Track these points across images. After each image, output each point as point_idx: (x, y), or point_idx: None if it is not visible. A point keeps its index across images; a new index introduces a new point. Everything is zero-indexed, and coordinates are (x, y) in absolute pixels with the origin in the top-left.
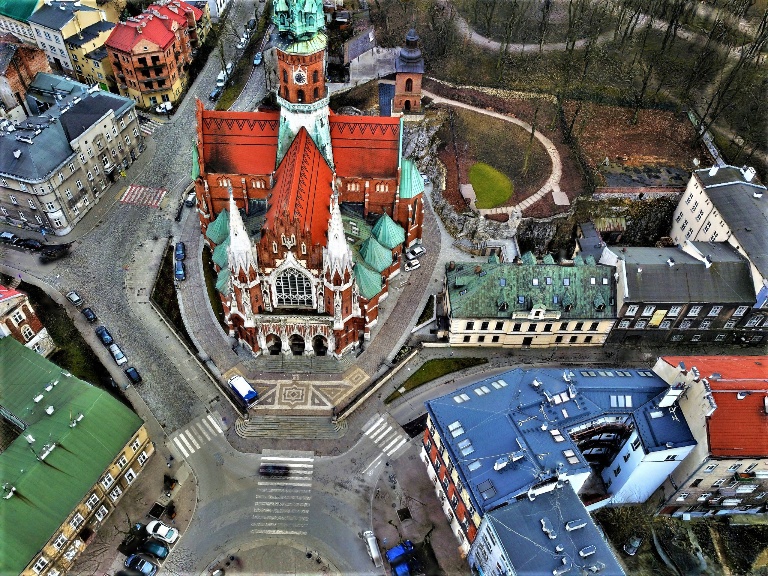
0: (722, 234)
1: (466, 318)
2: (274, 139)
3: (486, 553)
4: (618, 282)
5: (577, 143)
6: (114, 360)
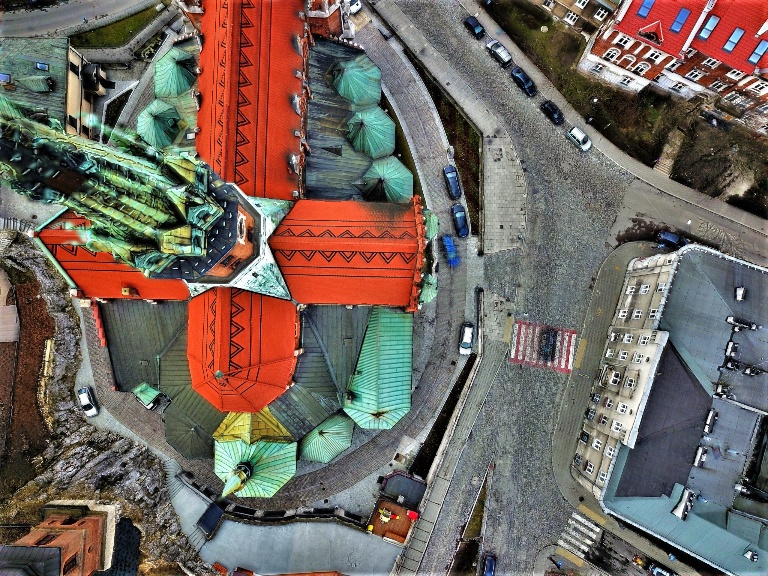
0: None
1: (50, 38)
2: (290, 224)
3: None
4: None
5: None
6: None
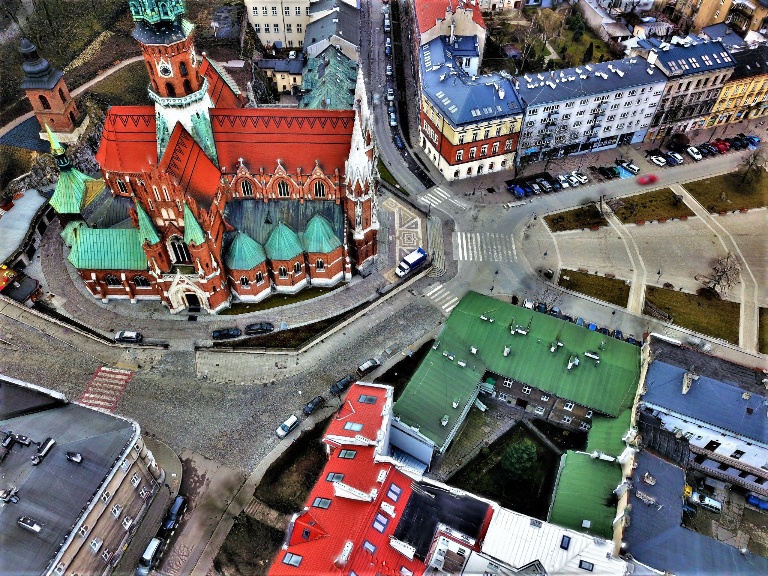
0: (303, 3)
1: None
2: (195, 147)
3: (530, 132)
4: (342, 49)
5: None
6: (375, 369)
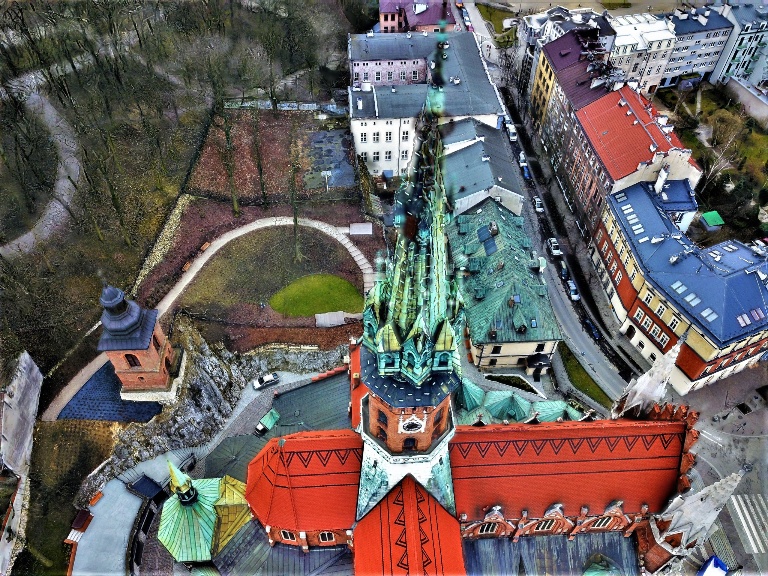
0: None
1: (559, 328)
2: (431, 503)
3: None
4: (502, 201)
5: (266, 198)
6: None
